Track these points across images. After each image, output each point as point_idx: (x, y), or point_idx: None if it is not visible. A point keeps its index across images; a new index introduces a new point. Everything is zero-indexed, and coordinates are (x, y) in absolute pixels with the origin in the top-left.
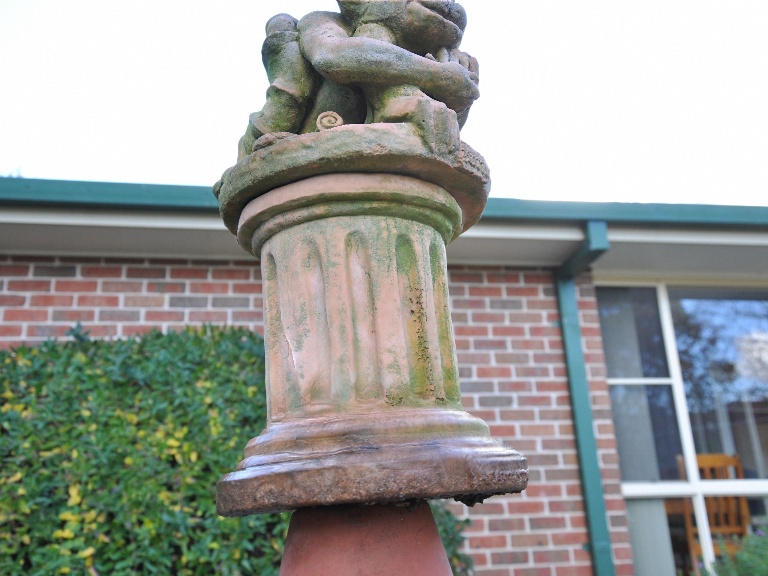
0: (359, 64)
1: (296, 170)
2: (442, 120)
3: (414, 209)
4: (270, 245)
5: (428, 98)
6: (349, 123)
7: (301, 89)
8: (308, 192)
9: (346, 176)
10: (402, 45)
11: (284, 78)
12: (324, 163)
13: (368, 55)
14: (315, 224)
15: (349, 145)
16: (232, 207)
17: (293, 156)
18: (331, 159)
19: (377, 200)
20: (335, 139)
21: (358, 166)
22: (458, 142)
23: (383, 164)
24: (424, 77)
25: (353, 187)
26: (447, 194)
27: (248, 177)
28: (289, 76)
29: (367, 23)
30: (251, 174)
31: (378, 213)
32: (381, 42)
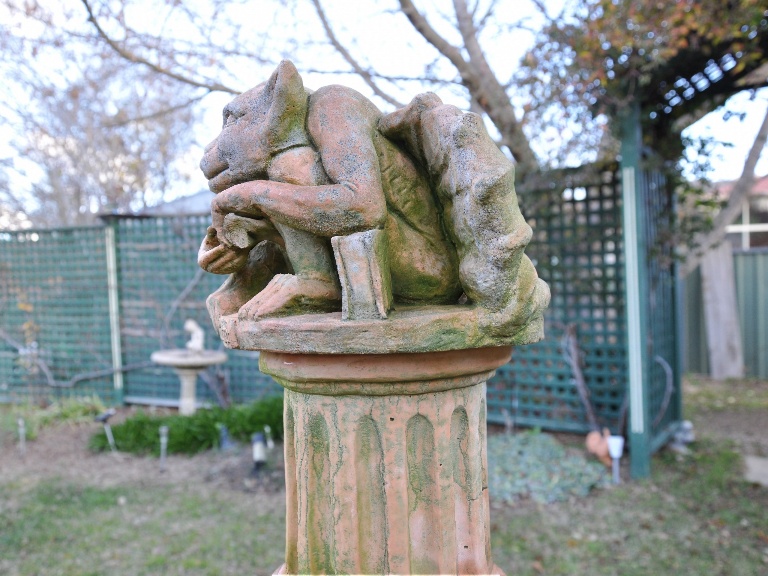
0: None
1: None
2: None
3: None
4: None
5: None
6: None
7: None
8: None
9: None
10: None
11: None
12: None
13: None
14: None
15: None
16: None
17: None
18: None
19: None
20: None
21: None
22: None
23: None
24: None
25: None
26: None
27: None
28: None
29: None
30: None
31: None
32: None
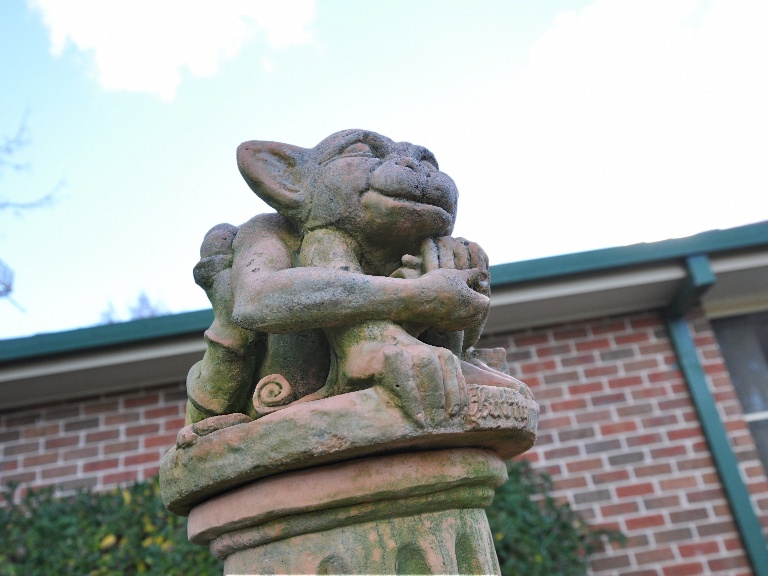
0: (291, 313)
1: (228, 481)
2: (427, 375)
3: (417, 501)
4: (226, 570)
5: (403, 341)
6: (314, 368)
7: (241, 335)
8: (251, 510)
9: (301, 478)
10: (368, 248)
11: (220, 321)
12: (262, 470)
13: (302, 298)
14: (273, 548)
15: (290, 443)
16: (178, 508)
17: (218, 465)
18: (269, 466)
19: (355, 504)
20: (270, 435)
21: (316, 461)
22: (463, 394)
23: (352, 453)
24: (393, 307)
25: (313, 496)
26: (468, 458)
27: (174, 488)
28: (224, 319)
29: (314, 230)
30: (176, 484)
31: (362, 520)
32: (319, 274)
